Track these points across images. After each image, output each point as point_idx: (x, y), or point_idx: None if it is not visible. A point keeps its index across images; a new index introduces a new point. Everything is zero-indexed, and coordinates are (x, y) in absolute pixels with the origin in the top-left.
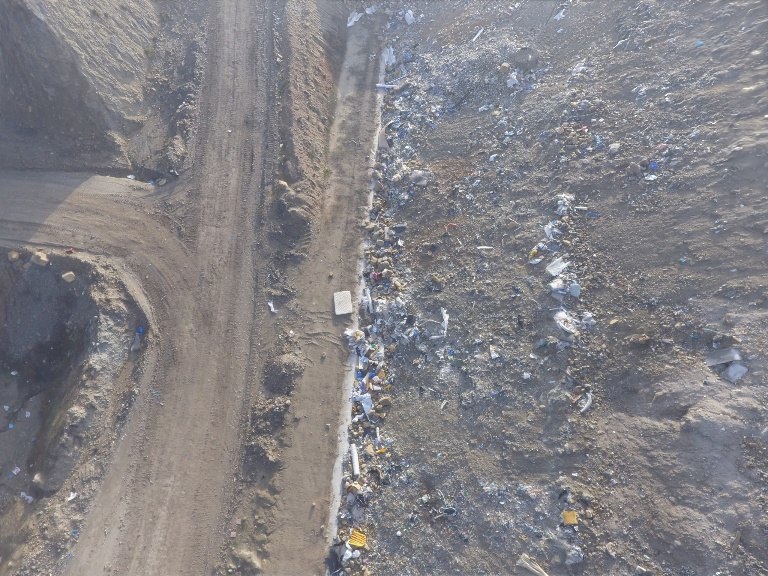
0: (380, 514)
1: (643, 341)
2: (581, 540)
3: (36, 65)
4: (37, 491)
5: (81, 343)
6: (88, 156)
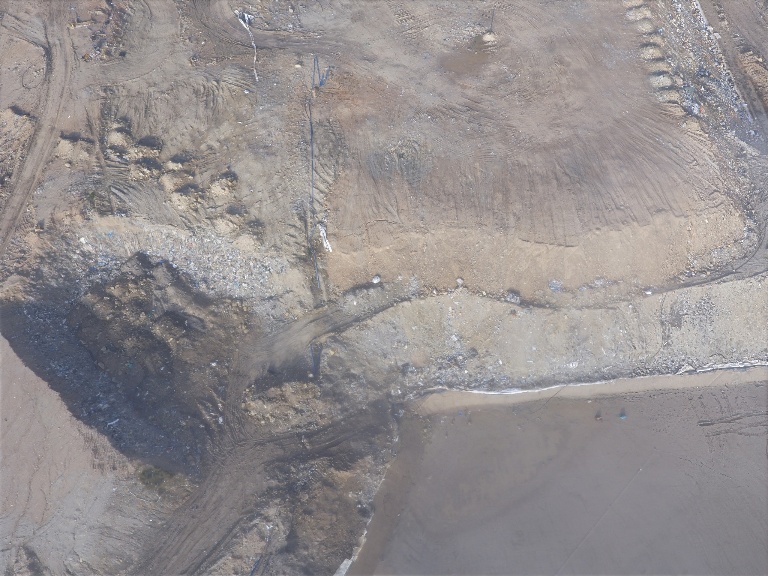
0: None
1: None
2: None
3: None
4: None
5: None
6: None
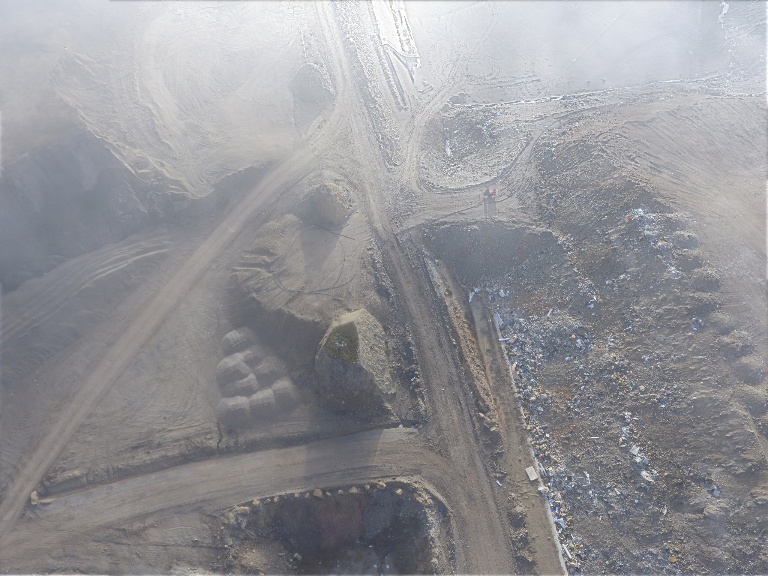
0: (588, 574)
1: (680, 482)
2: (680, 567)
3: (353, 384)
4: None
5: (417, 525)
6: (377, 420)
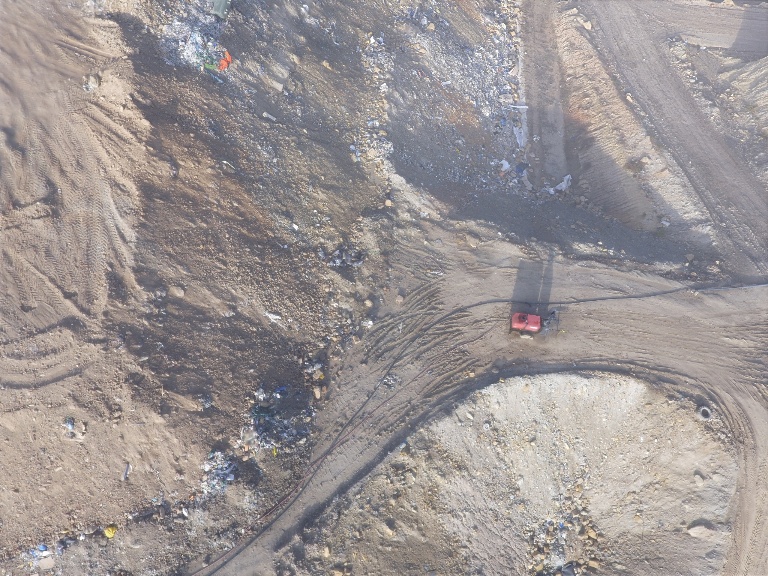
0: None
1: None
2: None
3: None
4: None
5: None
6: None
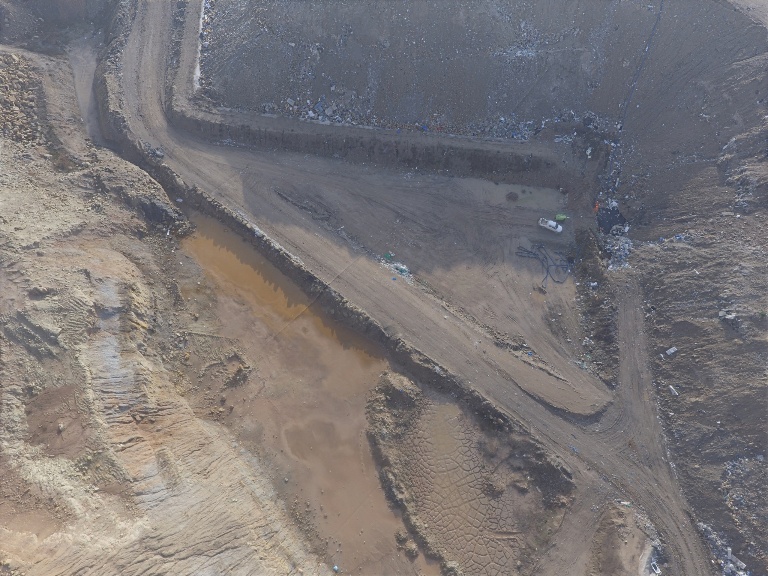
0: None
1: None
2: None
3: None
4: (111, 41)
5: (116, 2)
6: None
